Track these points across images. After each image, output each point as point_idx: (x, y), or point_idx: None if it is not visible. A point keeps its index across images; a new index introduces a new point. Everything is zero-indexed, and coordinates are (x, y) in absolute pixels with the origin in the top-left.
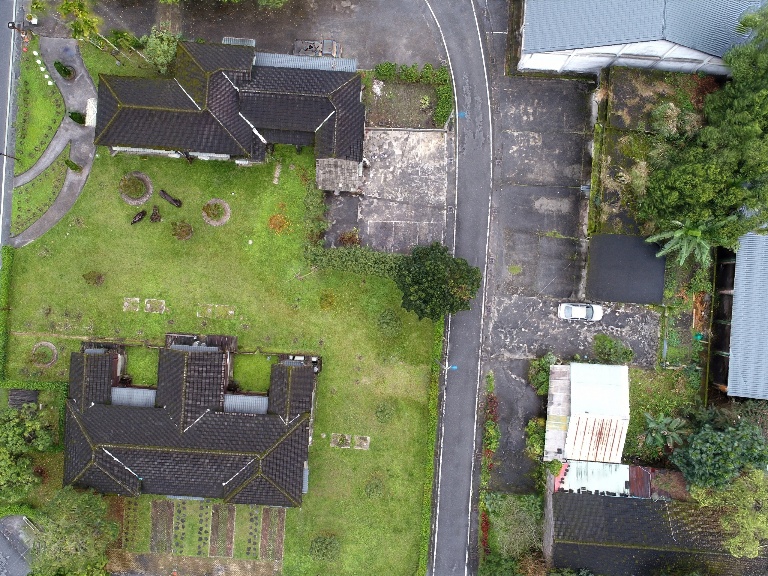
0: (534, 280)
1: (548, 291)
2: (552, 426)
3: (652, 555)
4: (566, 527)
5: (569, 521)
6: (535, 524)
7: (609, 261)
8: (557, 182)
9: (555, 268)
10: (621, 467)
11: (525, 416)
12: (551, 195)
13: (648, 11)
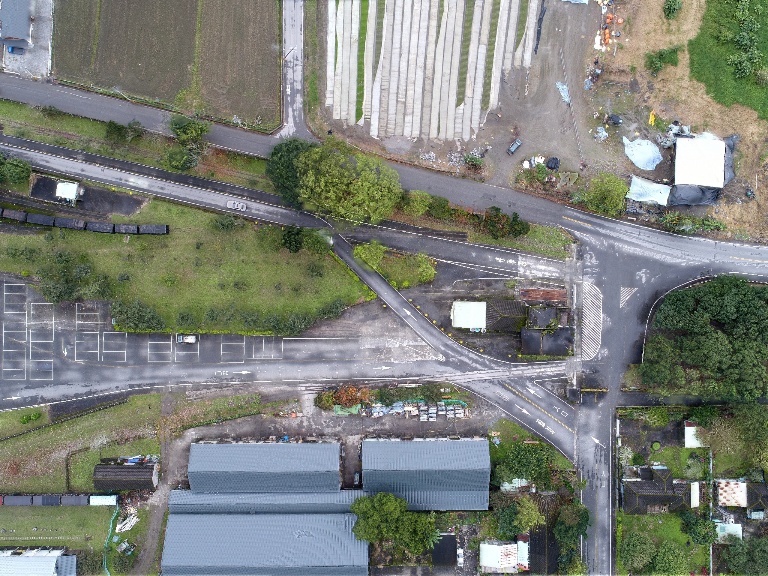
0: (449, 574)
1: (453, 569)
2: (505, 571)
3: (549, 538)
4: (542, 570)
5: (539, 569)
6: (543, 575)
7: (442, 558)
8: (410, 568)
9: (444, 567)
10: (518, 544)
11: (502, 574)
12: (415, 570)
13: (358, 570)
